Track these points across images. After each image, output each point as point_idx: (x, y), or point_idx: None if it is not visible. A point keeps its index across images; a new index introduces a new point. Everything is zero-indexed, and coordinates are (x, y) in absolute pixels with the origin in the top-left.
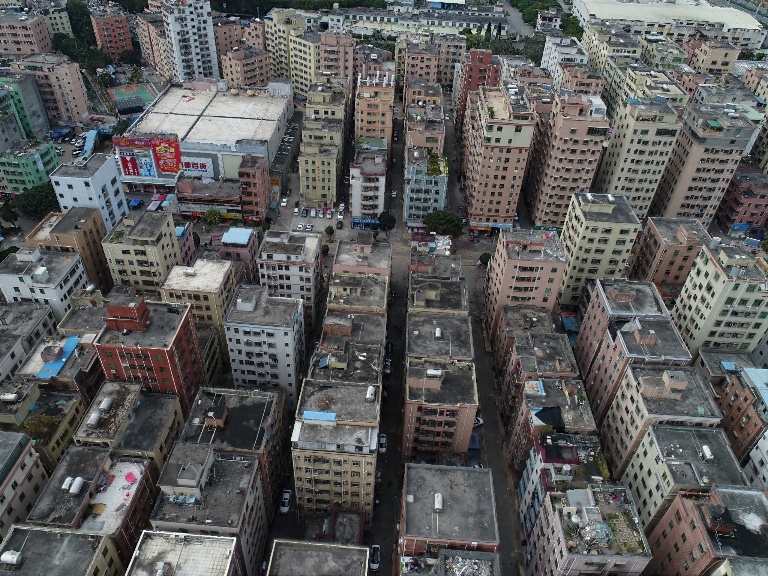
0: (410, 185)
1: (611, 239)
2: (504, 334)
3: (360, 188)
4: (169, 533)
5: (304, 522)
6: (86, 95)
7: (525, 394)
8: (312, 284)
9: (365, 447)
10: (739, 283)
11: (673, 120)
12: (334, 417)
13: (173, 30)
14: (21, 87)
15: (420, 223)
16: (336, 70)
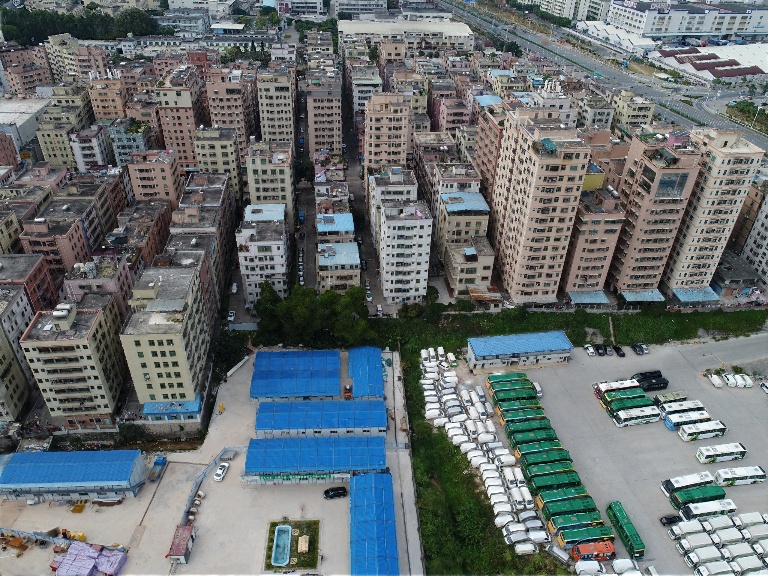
0: (115, 143)
1: (218, 153)
2: None
3: (79, 148)
4: None
5: None
6: None
7: (109, 233)
8: None
9: None
10: (254, 158)
11: (285, 80)
12: None
13: None
14: None
15: None
16: None
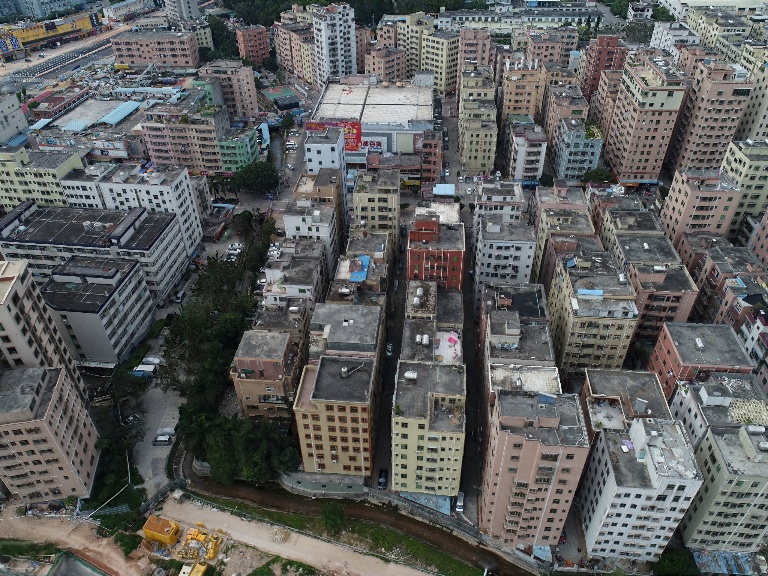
0: (569, 149)
1: None
2: (688, 253)
3: (524, 153)
4: (508, 365)
5: (570, 380)
6: None
7: (730, 286)
8: (519, 221)
9: (630, 312)
10: None
11: None
12: (602, 293)
13: (325, 35)
14: (213, 88)
15: (575, 182)
16: None
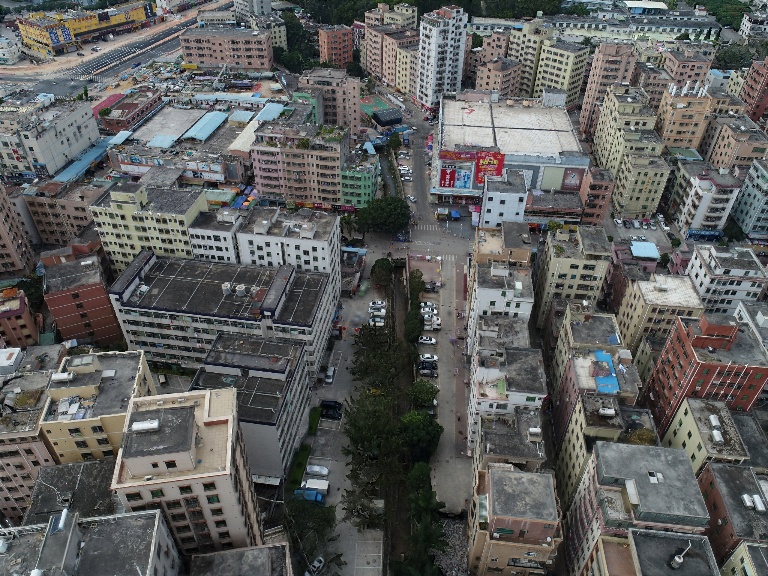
0: (767, 197)
1: None
2: None
3: (710, 200)
4: None
5: None
6: None
7: None
8: None
9: None
10: None
11: None
12: None
13: (436, 43)
14: (317, 102)
15: (765, 235)
16: (614, 80)
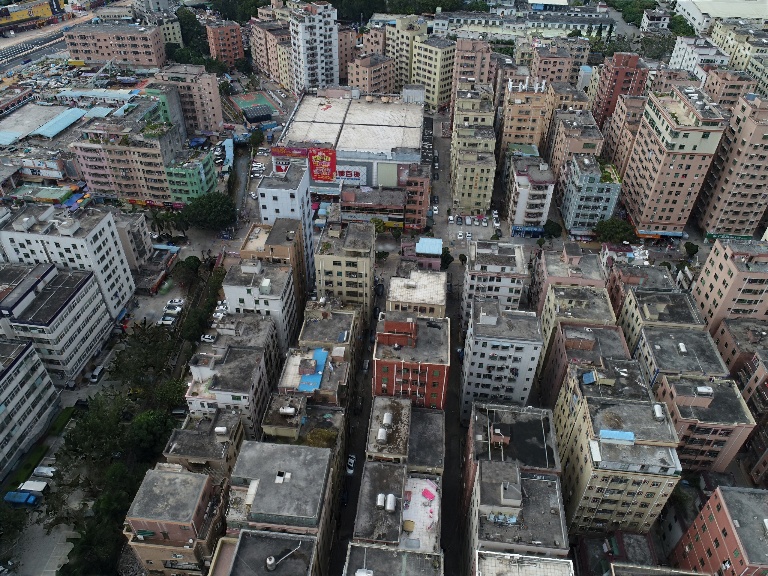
0: (580, 193)
1: None
2: (730, 348)
3: (527, 196)
4: (502, 554)
5: (583, 541)
6: (220, 104)
7: None
8: None
9: (671, 468)
10: None
11: None
12: (633, 437)
13: (302, 39)
14: (168, 98)
15: (585, 231)
16: (471, 76)
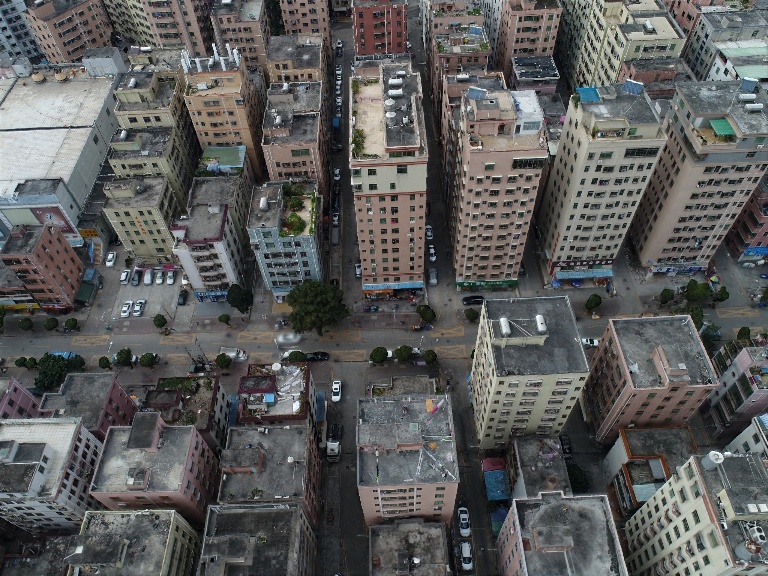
0: (260, 250)
1: (543, 390)
2: None
3: (191, 258)
4: None
5: None
6: None
7: None
8: (73, 509)
9: None
10: (754, 566)
11: (653, 132)
12: None
13: None
14: None
15: None
16: (174, 29)
